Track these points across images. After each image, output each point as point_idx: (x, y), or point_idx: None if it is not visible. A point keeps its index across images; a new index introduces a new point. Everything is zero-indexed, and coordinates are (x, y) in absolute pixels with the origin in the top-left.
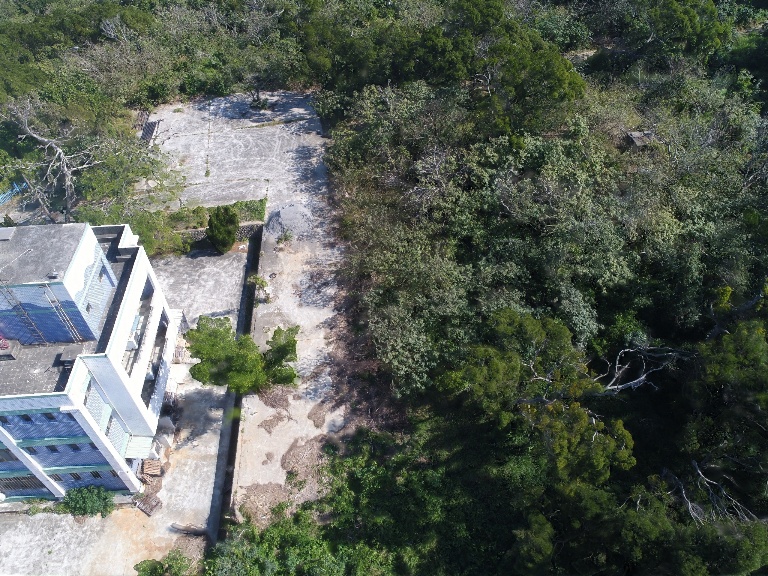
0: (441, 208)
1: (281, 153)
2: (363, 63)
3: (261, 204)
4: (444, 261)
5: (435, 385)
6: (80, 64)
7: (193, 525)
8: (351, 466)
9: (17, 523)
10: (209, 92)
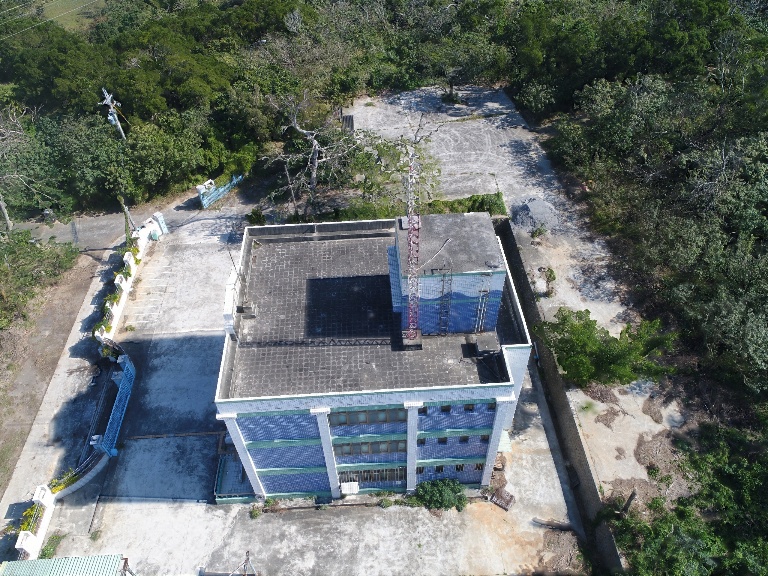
0: (725, 202)
1: (495, 147)
2: (570, 57)
3: (498, 198)
4: None
5: None
6: (263, 57)
7: (555, 520)
8: (715, 462)
9: (373, 516)
10: (394, 86)
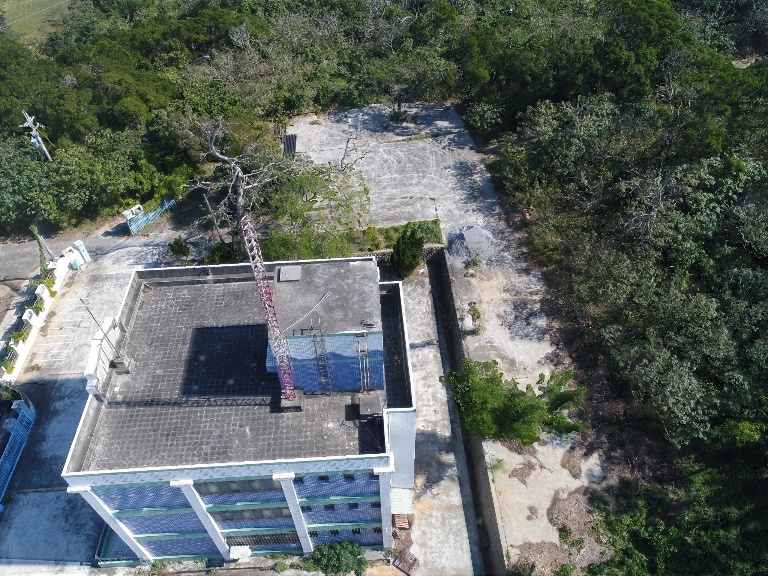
0: (662, 235)
1: (439, 169)
2: (519, 75)
3: (436, 225)
4: (698, 296)
5: (717, 436)
6: (207, 73)
7: None
8: (631, 524)
9: None
10: (342, 103)
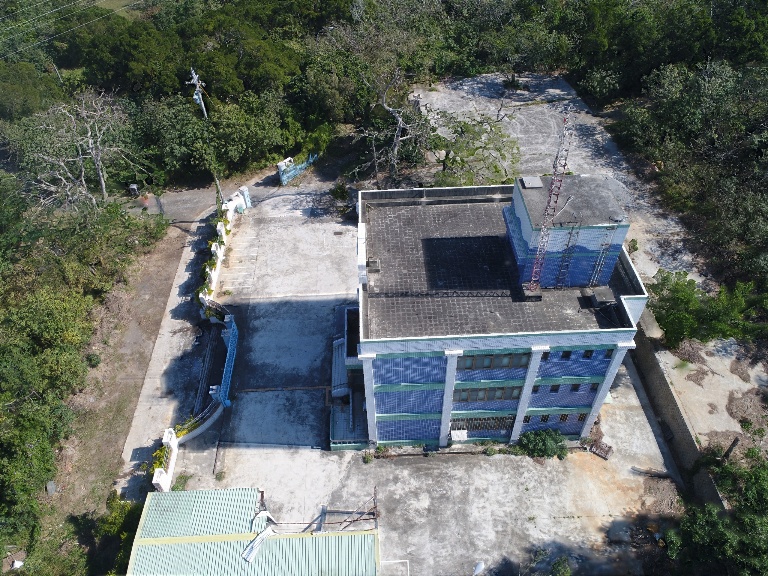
0: None
1: (561, 130)
2: (633, 45)
3: None
4: None
5: None
6: None
7: (653, 469)
8: None
9: (480, 462)
10: (456, 73)
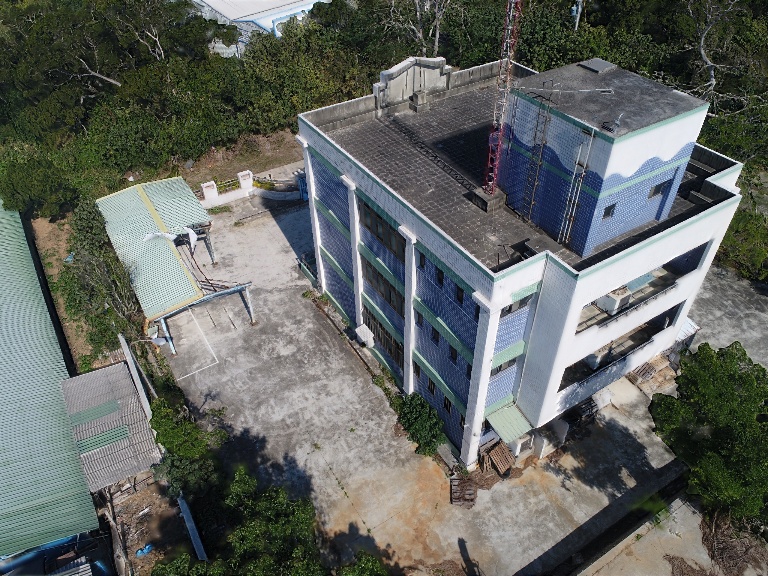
0: None
1: None
2: None
3: None
4: None
5: None
6: None
7: (478, 568)
8: None
9: (359, 377)
10: None
